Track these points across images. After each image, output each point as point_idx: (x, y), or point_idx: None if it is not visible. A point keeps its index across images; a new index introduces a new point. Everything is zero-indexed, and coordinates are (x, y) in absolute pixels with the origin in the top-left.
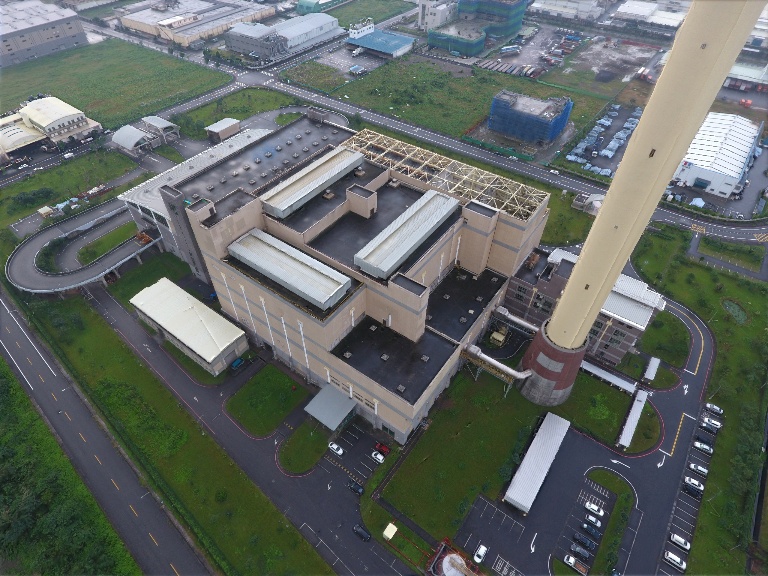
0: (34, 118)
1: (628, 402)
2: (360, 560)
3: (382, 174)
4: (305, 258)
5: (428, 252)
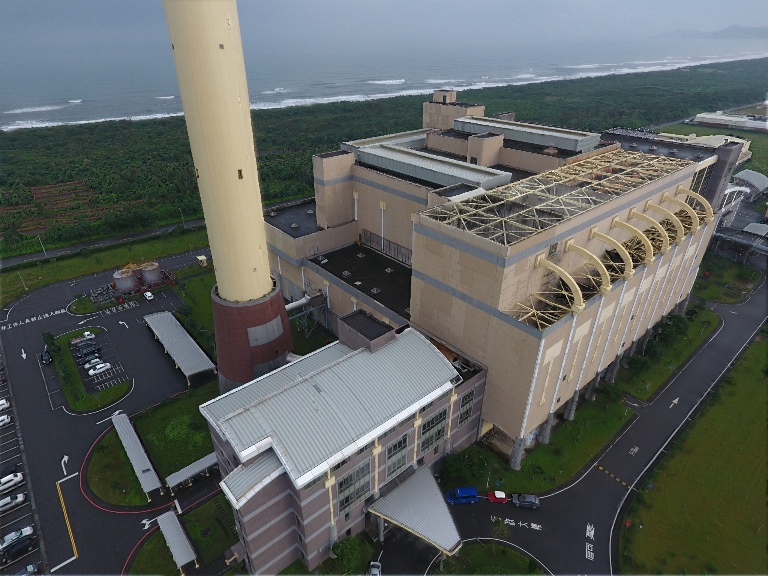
0: (694, 139)
1: (163, 473)
2: (200, 255)
3: (547, 156)
4: (400, 140)
5: (389, 176)
